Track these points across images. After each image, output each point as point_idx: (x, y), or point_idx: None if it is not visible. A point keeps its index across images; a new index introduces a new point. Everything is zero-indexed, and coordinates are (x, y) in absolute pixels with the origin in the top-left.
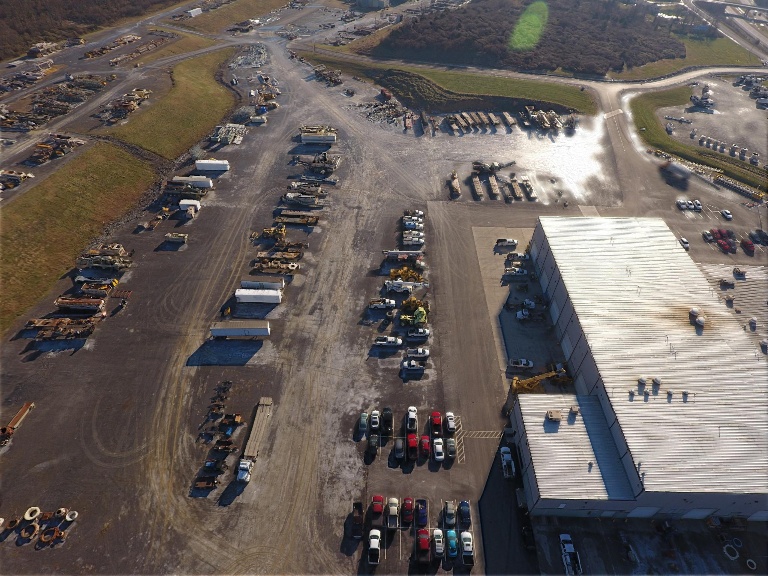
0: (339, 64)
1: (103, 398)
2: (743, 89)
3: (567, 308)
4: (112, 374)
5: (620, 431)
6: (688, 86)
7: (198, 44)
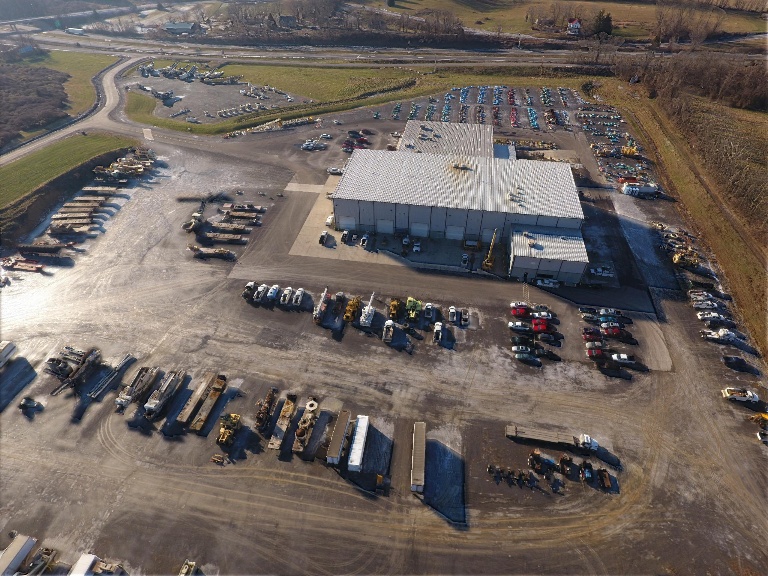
0: None
1: None
2: (155, 76)
3: (437, 214)
4: None
5: (547, 217)
6: (128, 92)
7: None
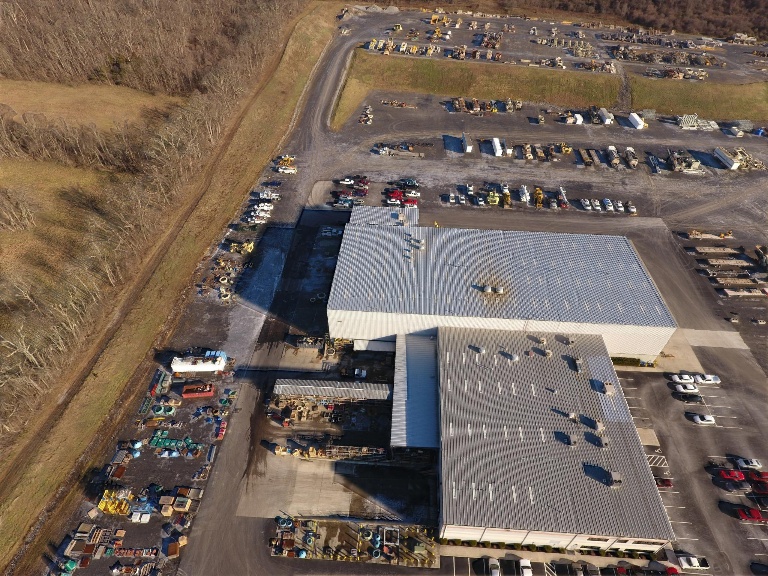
0: None
1: (422, 120)
2: None
3: None
4: (435, 120)
5: None
6: None
7: None
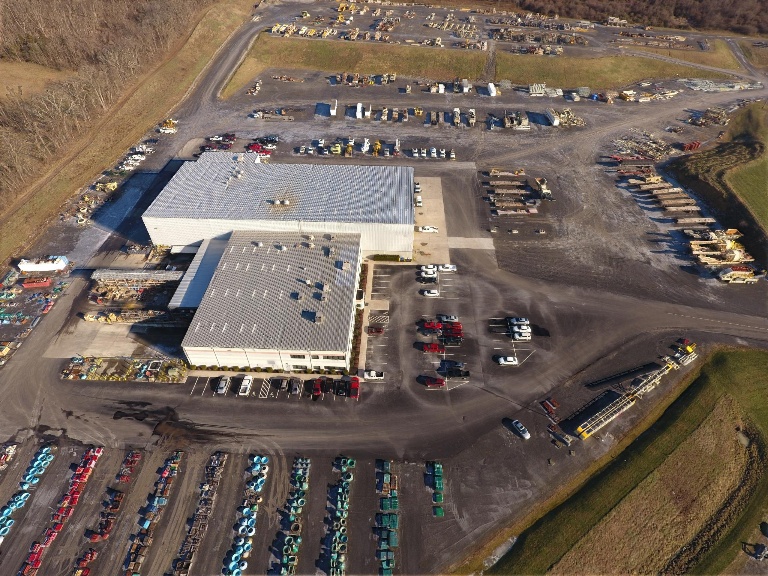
0: (750, 120)
1: (303, 91)
2: None
3: None
4: (315, 91)
5: None
6: None
7: (708, 61)
